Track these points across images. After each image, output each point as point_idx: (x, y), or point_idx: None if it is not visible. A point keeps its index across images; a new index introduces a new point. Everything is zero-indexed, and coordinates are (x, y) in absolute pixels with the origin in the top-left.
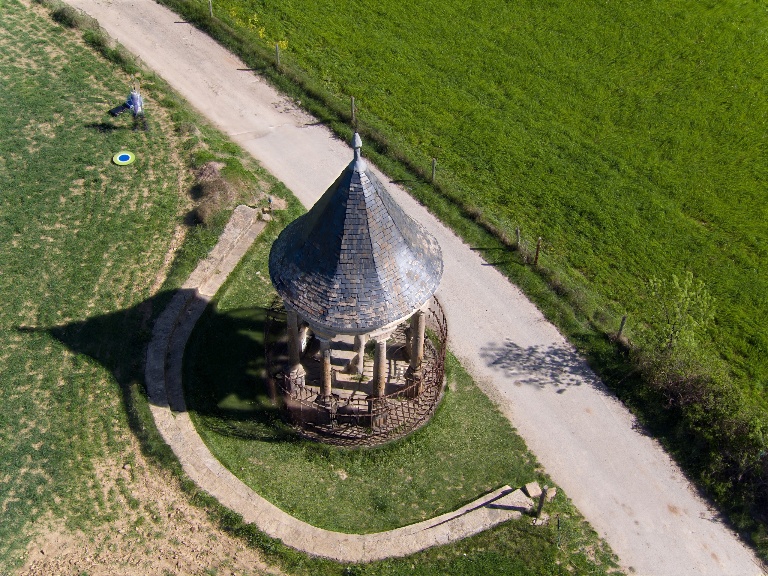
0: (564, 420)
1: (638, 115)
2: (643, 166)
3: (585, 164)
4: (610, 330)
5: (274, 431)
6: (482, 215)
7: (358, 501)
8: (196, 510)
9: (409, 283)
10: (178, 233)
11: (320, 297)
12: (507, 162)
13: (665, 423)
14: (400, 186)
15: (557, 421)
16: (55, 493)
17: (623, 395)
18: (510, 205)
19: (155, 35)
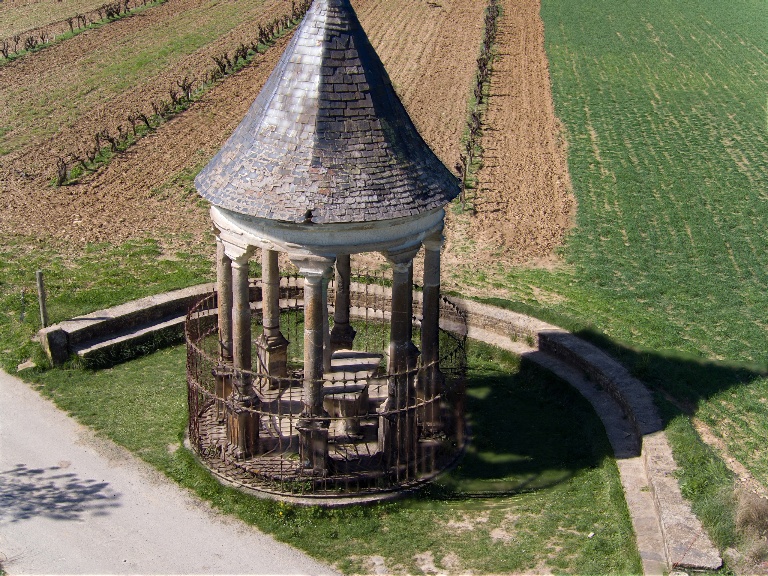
0: None
1: None
2: None
3: None
4: None
5: None
6: None
7: None
8: None
9: None
10: None
11: None
12: None
13: None
14: None
15: (4, 431)
16: None
17: None
18: None
19: None
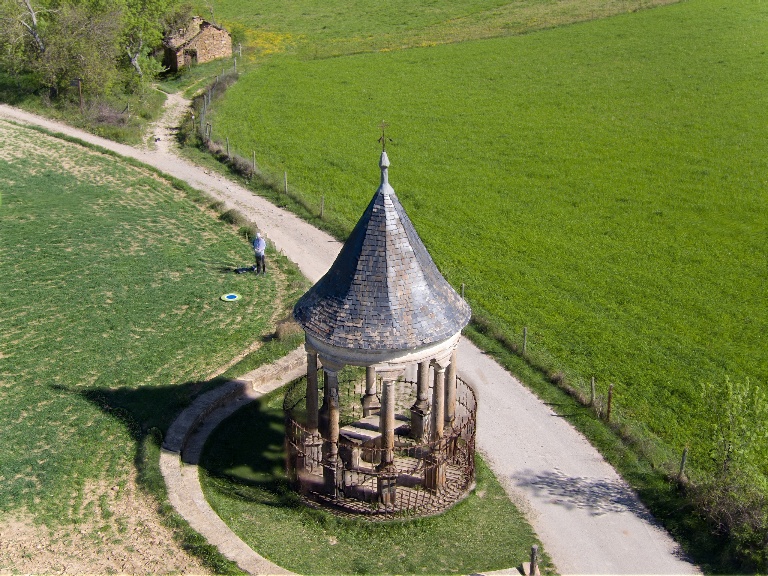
0: (595, 535)
1: (760, 336)
2: (754, 369)
3: (690, 361)
4: (671, 472)
5: (278, 497)
6: (565, 380)
7: (339, 563)
8: (164, 529)
9: (422, 318)
10: (253, 346)
11: (329, 317)
12: (607, 351)
13: (711, 550)
14: (490, 356)
15: (586, 535)
16: (38, 496)
17: (670, 524)
18: (599, 382)
19: (307, 247)
